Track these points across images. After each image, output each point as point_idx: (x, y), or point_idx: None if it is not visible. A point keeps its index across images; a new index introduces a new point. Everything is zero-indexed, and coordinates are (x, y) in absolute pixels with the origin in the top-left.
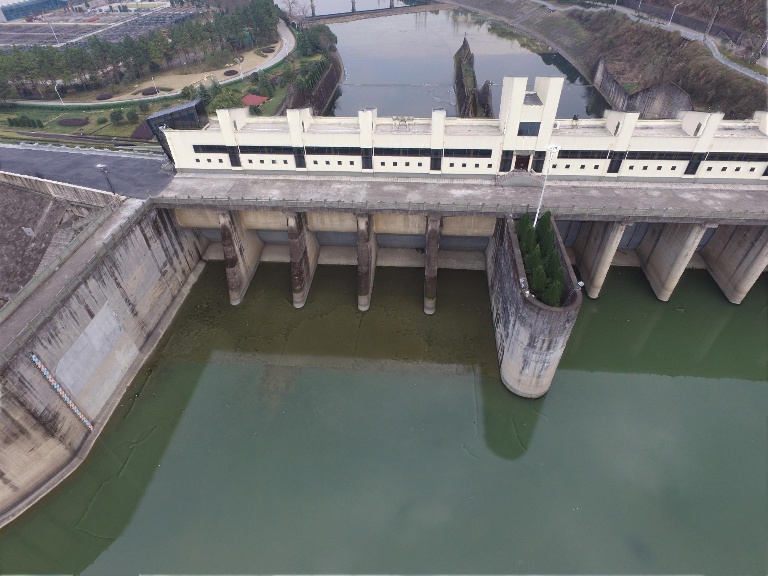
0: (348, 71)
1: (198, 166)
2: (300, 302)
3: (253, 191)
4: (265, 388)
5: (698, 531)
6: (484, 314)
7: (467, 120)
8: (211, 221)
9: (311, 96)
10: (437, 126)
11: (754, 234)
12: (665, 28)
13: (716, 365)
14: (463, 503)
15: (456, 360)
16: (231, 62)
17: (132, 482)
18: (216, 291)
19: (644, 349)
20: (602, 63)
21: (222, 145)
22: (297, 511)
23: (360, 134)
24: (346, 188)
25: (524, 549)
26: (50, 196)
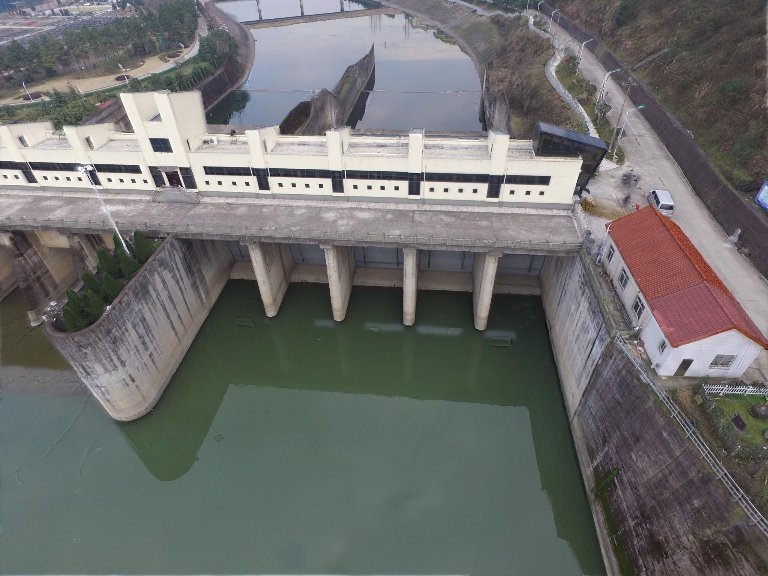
0: (255, 76)
1: None
2: None
3: None
4: None
5: (185, 567)
6: None
7: (131, 134)
8: None
9: None
10: (74, 141)
11: None
12: (542, 35)
13: (425, 386)
14: None
15: None
16: (129, 67)
17: None
18: None
19: (351, 368)
20: None
21: None
22: None
23: (8, 148)
24: (7, 202)
25: None
26: None
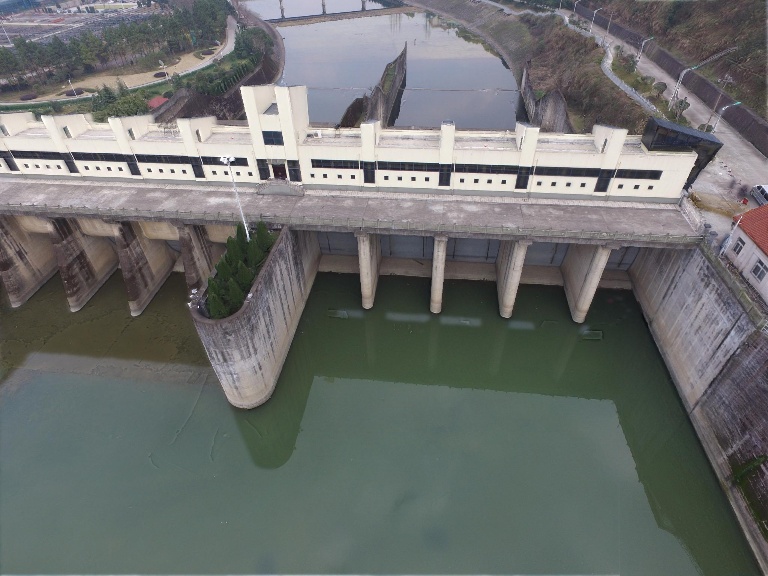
0: (288, 74)
1: None
2: (75, 306)
3: (21, 195)
4: None
5: (335, 549)
6: None
7: (234, 128)
8: None
9: (223, 99)
10: (185, 134)
11: (509, 247)
12: (584, 34)
13: (511, 379)
14: (119, 513)
15: (195, 368)
16: (166, 64)
17: None
18: (6, 293)
19: (438, 361)
20: (525, 68)
21: None
22: None
23: (117, 141)
24: (112, 194)
25: (154, 561)
26: None
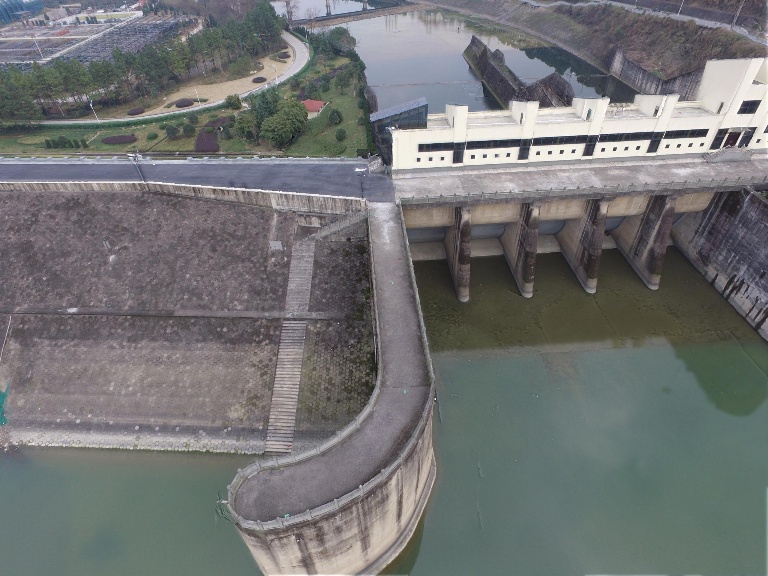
0: (365, 73)
1: (417, 166)
2: (531, 291)
3: (488, 185)
4: (556, 375)
5: None
6: (702, 284)
7: None
8: (434, 220)
9: None
10: (667, 109)
11: None
12: (677, 18)
13: None
14: None
15: (711, 327)
16: (253, 69)
17: (501, 480)
18: (435, 291)
19: None
20: (620, 53)
21: (449, 142)
22: (673, 482)
23: (592, 122)
24: (574, 176)
25: None
26: (270, 208)
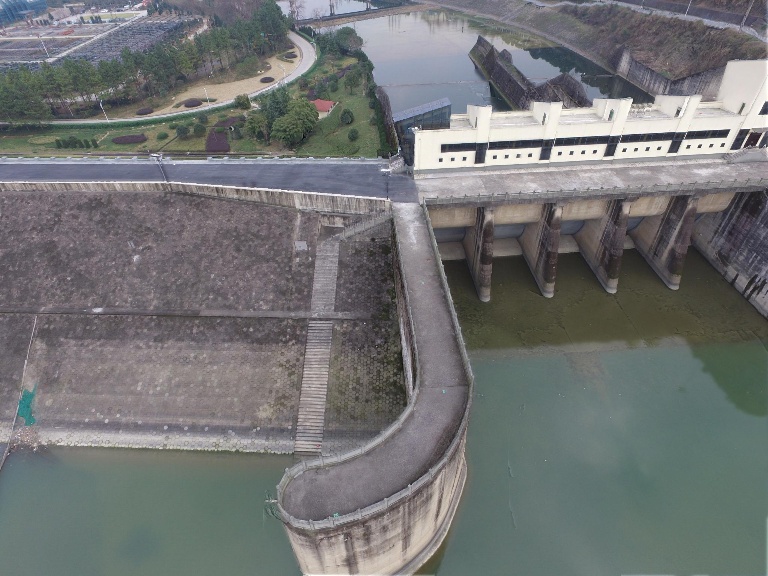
0: None
1: (439, 166)
2: (552, 291)
3: (510, 186)
4: (581, 375)
5: None
6: (722, 284)
7: None
8: (456, 220)
9: None
10: (690, 110)
11: None
12: (684, 18)
13: None
14: None
15: (733, 327)
16: (260, 69)
17: (532, 480)
18: (456, 291)
19: None
20: (627, 53)
21: (472, 143)
22: (703, 481)
23: (614, 122)
24: (596, 176)
25: None
26: (293, 208)
